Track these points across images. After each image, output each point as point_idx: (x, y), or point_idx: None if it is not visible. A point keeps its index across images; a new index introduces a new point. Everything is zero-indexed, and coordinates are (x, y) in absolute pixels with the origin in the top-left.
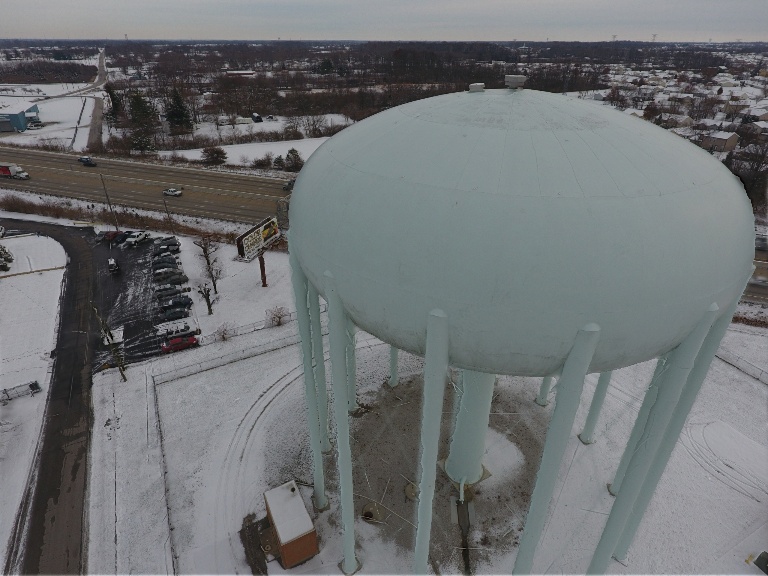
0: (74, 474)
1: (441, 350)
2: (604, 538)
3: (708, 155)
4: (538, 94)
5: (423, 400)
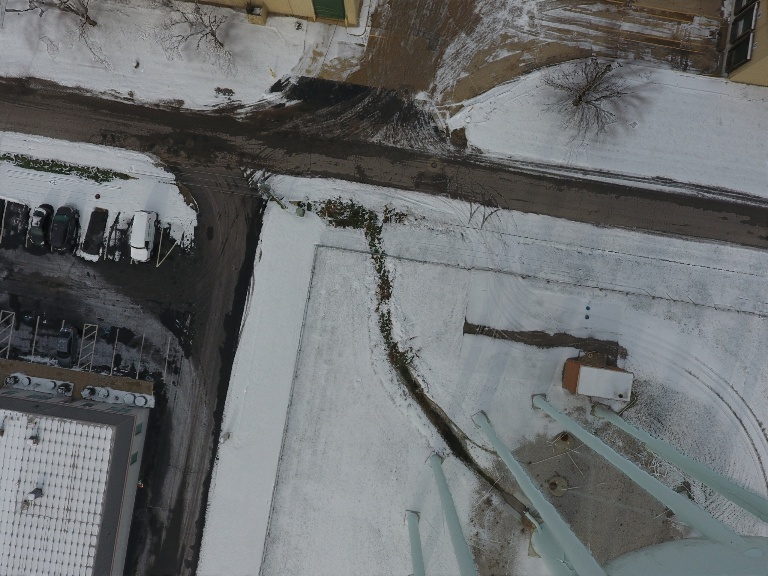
0: (767, 238)
1: (585, 573)
2: (422, 571)
3: None
4: None
5: None
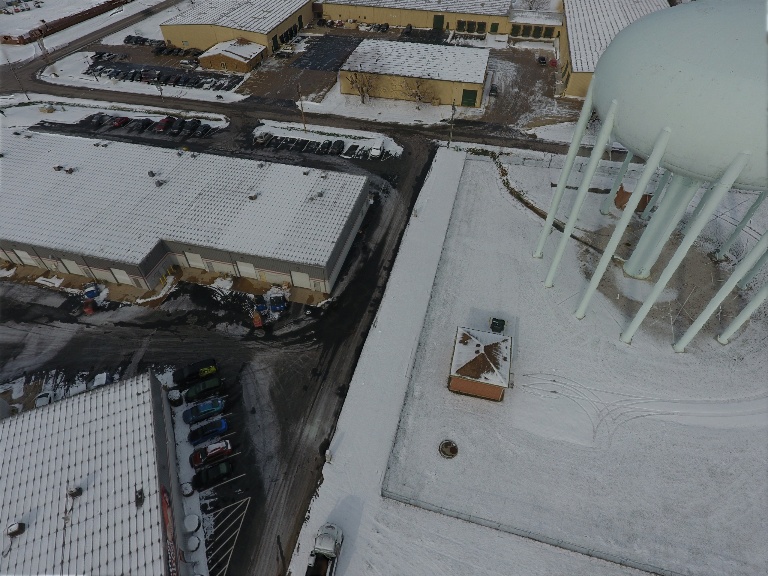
0: None
1: None
2: None
3: (682, 51)
4: (766, 4)
5: (712, 289)
